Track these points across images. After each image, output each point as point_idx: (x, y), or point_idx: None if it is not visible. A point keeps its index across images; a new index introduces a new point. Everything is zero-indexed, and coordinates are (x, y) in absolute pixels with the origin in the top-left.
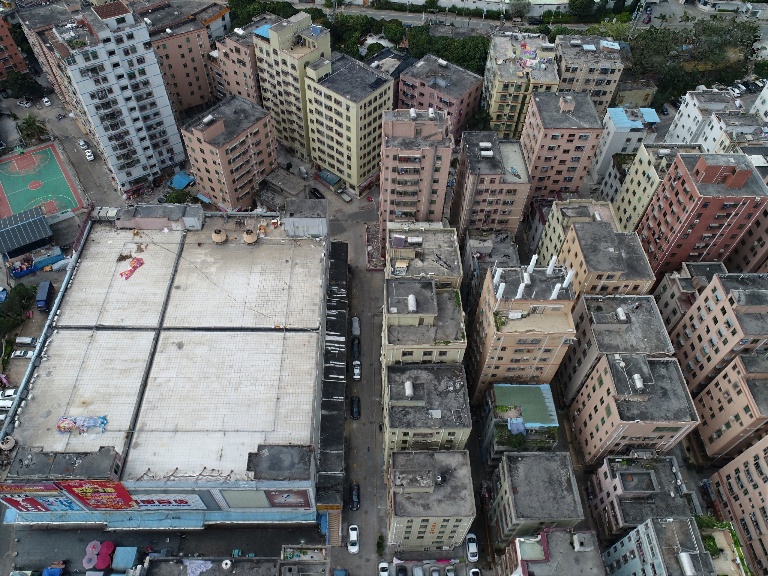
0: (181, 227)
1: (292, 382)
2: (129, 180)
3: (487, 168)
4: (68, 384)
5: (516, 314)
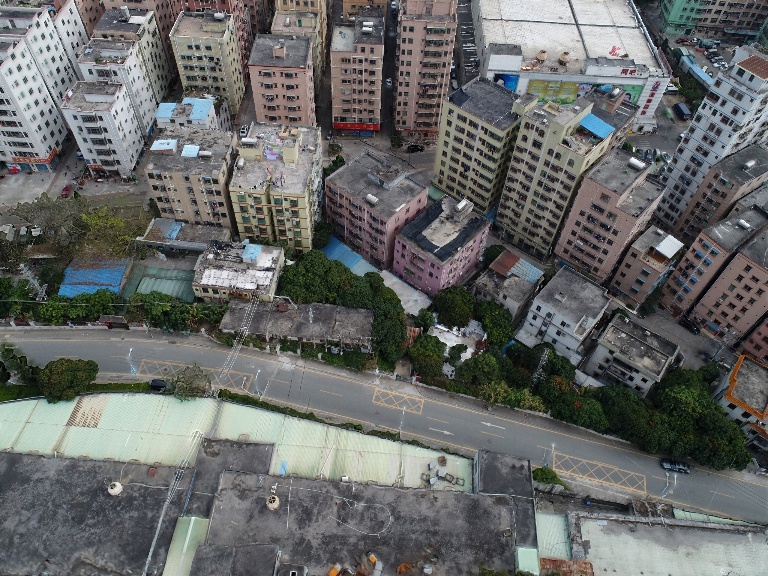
0: None
1: (492, 2)
2: None
3: (369, 21)
4: (612, 8)
5: None
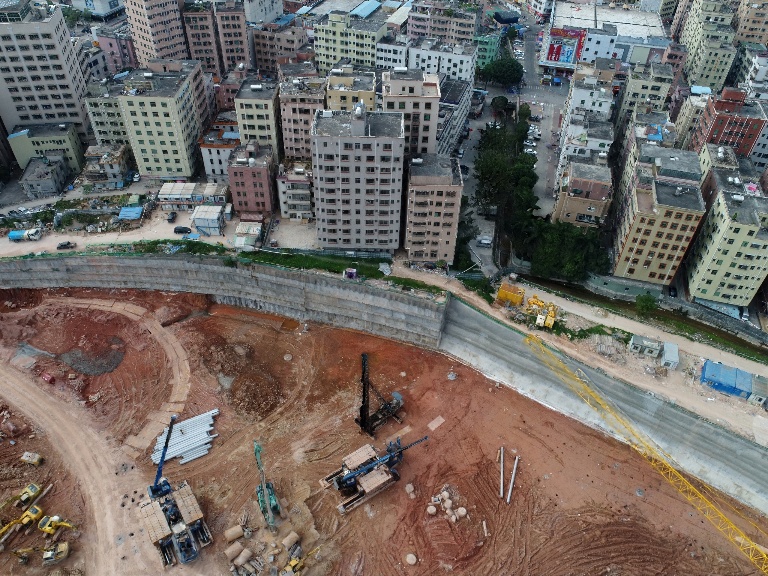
0: (594, 3)
1: None
2: (548, 8)
3: None
4: None
5: (756, 5)
